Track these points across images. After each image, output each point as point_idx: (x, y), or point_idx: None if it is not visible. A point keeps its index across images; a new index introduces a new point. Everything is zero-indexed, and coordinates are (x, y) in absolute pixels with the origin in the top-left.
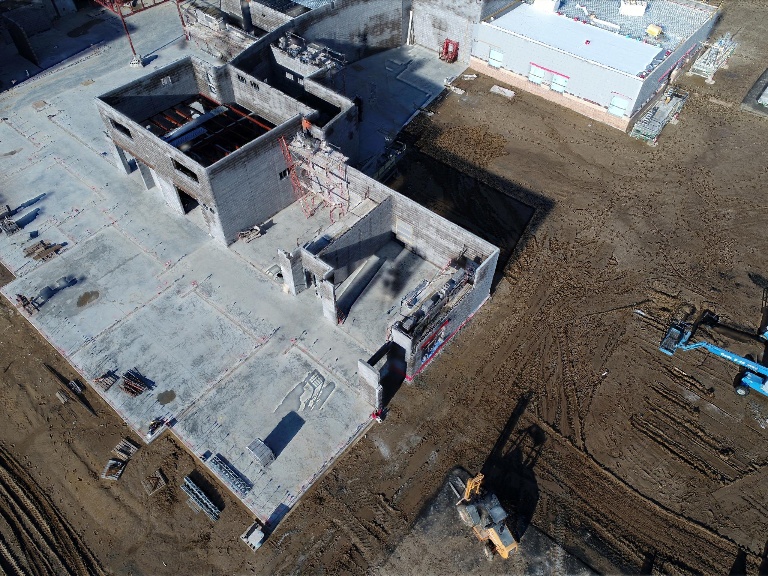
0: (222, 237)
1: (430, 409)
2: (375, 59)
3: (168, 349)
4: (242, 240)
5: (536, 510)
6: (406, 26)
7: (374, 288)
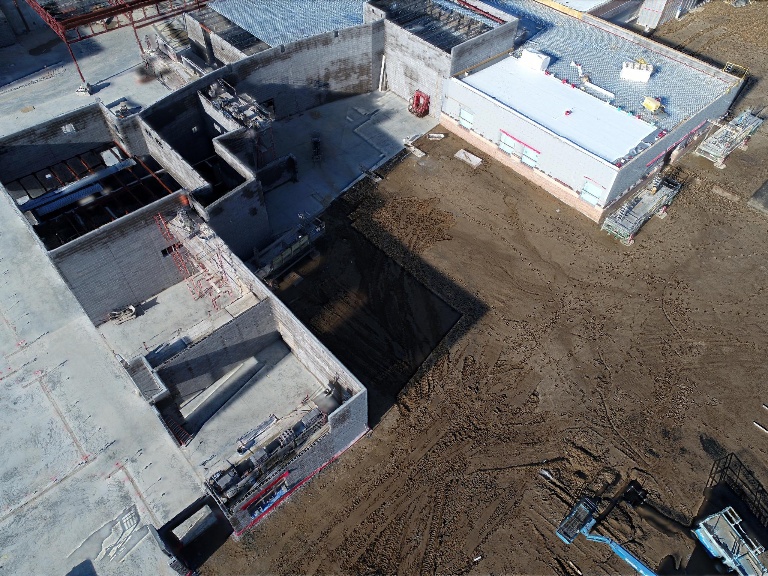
0: (88, 317)
1: None
2: (338, 105)
3: None
4: (112, 321)
5: None
6: (378, 71)
7: (238, 402)
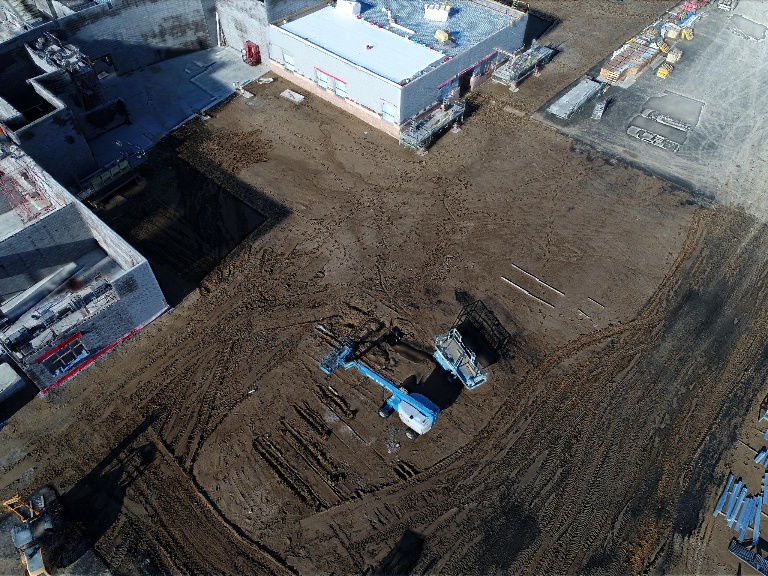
0: None
1: (50, 424)
2: (178, 61)
3: None
4: None
5: (106, 533)
6: (214, 27)
7: (55, 297)
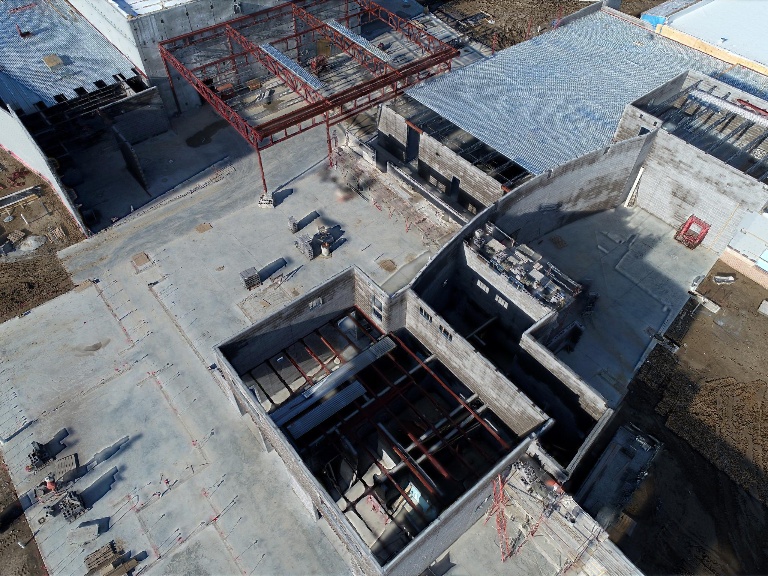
0: None
1: None
2: (581, 228)
3: None
4: None
5: None
6: (629, 184)
7: None
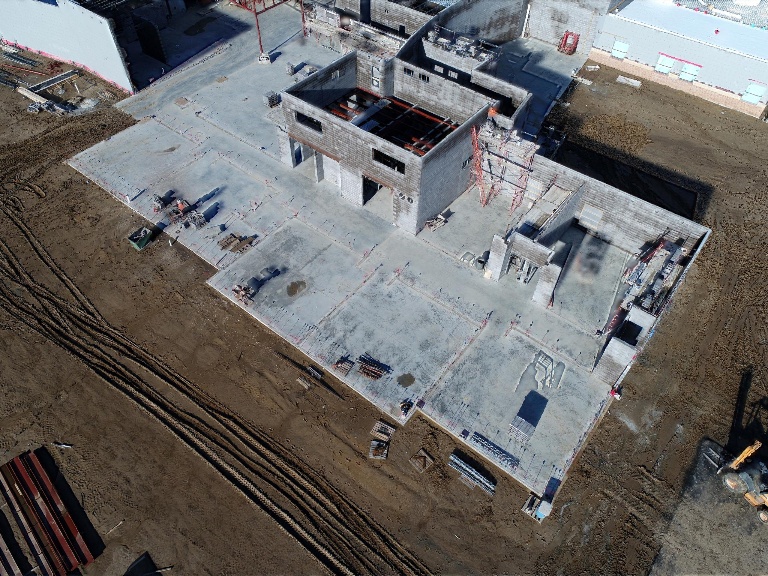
0: (412, 226)
1: (661, 385)
2: None
3: (392, 334)
4: (429, 229)
5: None
6: (523, 19)
7: (570, 272)
